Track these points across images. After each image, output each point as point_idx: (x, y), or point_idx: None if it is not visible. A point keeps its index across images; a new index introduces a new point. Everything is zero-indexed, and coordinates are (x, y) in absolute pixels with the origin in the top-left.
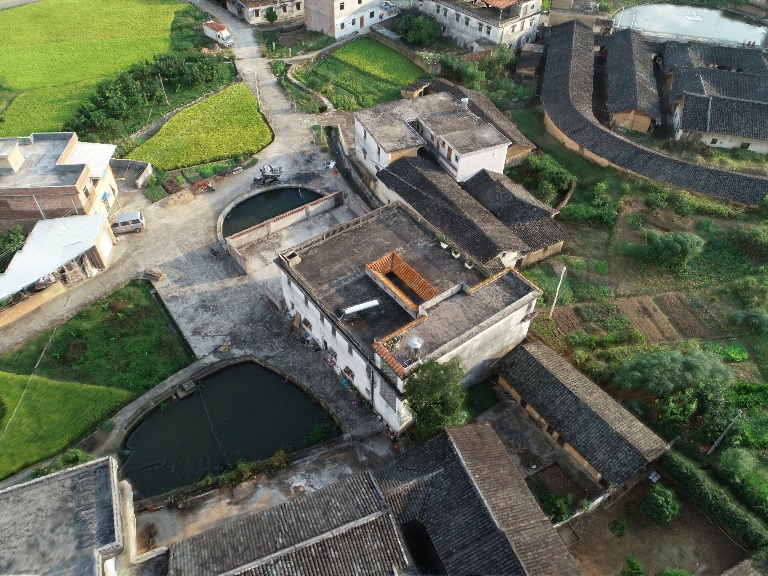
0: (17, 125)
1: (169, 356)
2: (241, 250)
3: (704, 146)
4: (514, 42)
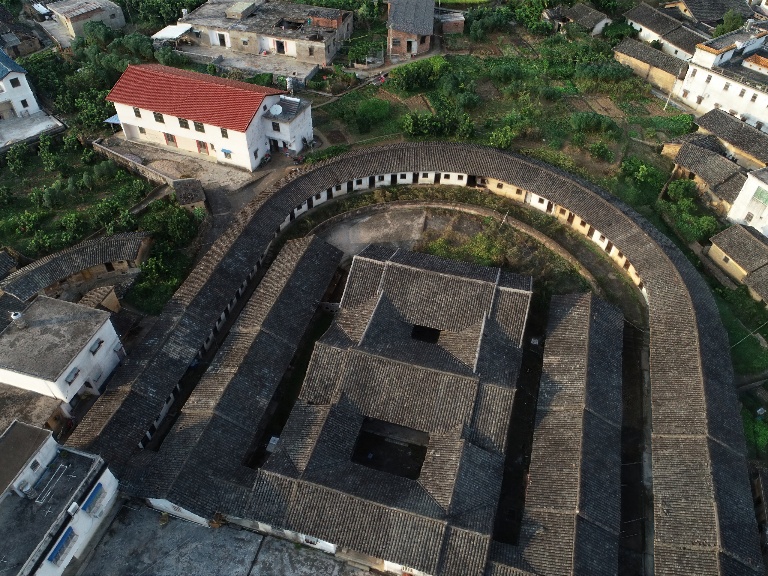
0: None
1: None
2: None
3: None
4: None
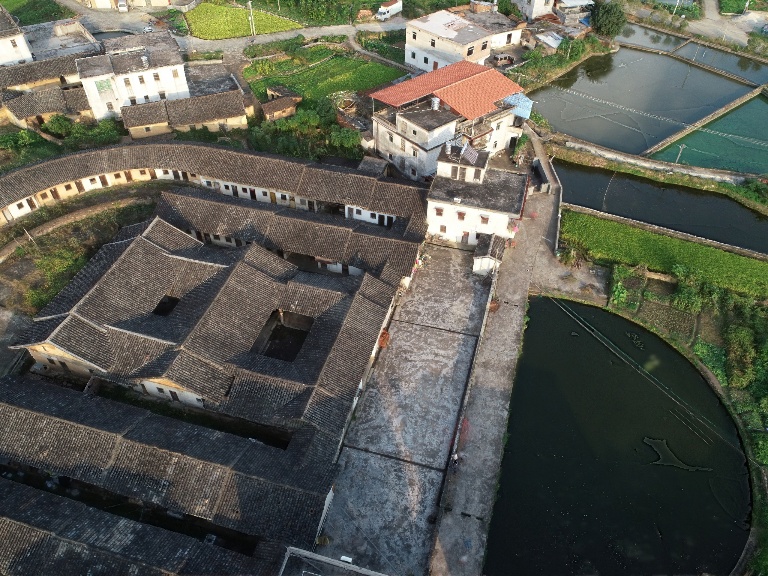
0: None
1: None
2: (80, 34)
3: None
4: (396, 156)
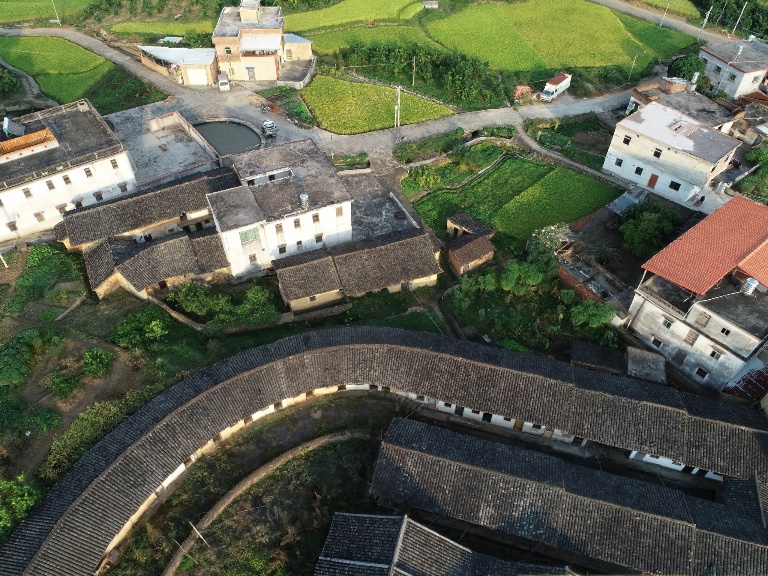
0: (364, 33)
1: None
2: (180, 127)
3: (282, 541)
4: (669, 345)
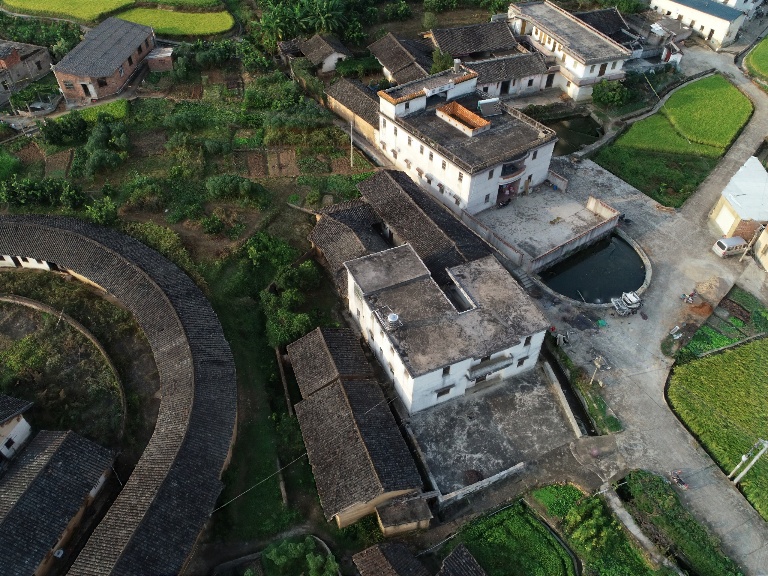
0: None
1: (609, 164)
2: None
3: None
4: None
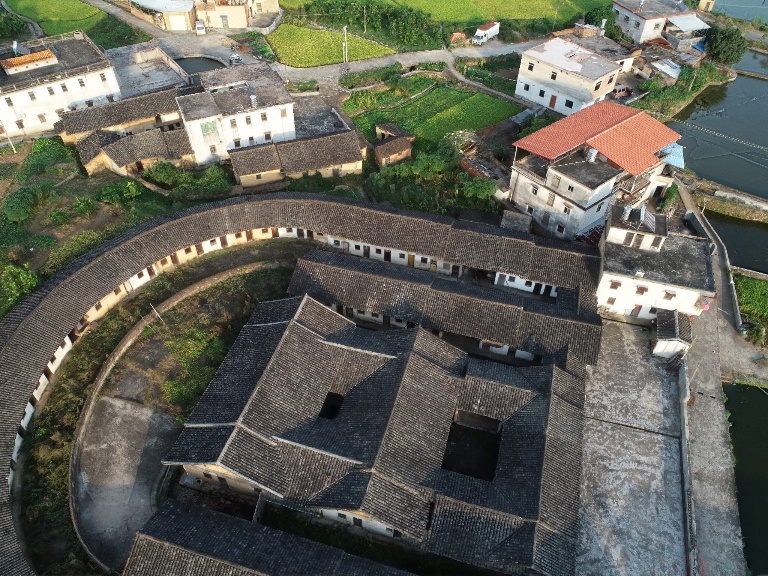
0: None
1: None
2: None
3: (219, 319)
4: (538, 210)
